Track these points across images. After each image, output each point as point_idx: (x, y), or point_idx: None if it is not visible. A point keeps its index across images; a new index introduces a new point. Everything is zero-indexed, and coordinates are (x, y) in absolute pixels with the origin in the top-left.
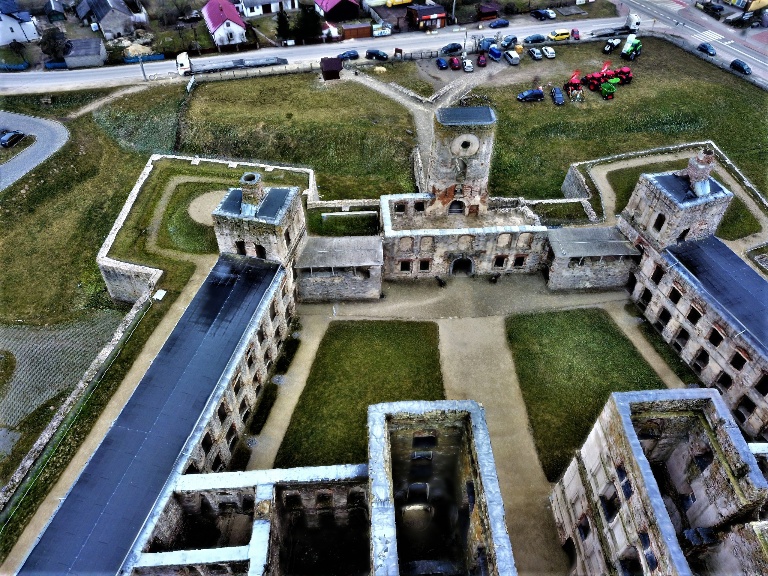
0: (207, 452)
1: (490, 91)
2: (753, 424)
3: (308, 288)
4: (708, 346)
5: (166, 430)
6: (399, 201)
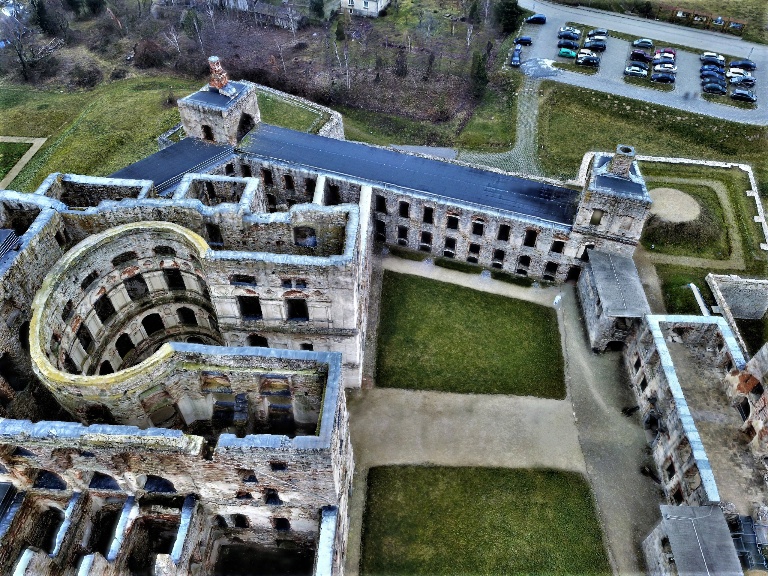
0: (403, 216)
1: None
2: None
3: (583, 280)
4: None
5: (402, 175)
6: (721, 336)
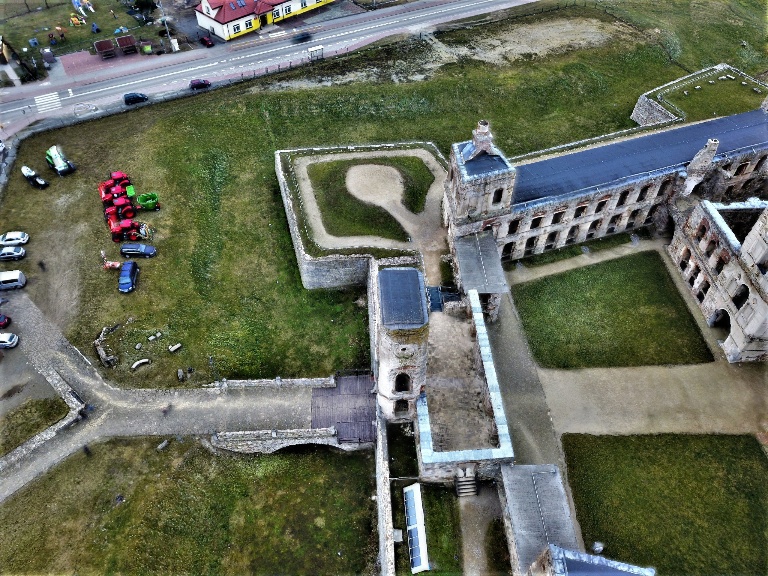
0: None
1: (88, 322)
2: (623, 224)
3: None
4: (577, 221)
5: None
6: None
